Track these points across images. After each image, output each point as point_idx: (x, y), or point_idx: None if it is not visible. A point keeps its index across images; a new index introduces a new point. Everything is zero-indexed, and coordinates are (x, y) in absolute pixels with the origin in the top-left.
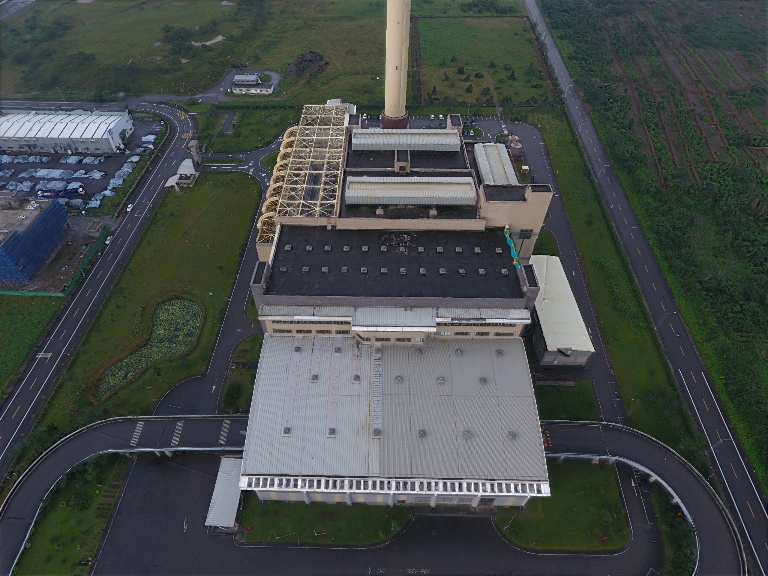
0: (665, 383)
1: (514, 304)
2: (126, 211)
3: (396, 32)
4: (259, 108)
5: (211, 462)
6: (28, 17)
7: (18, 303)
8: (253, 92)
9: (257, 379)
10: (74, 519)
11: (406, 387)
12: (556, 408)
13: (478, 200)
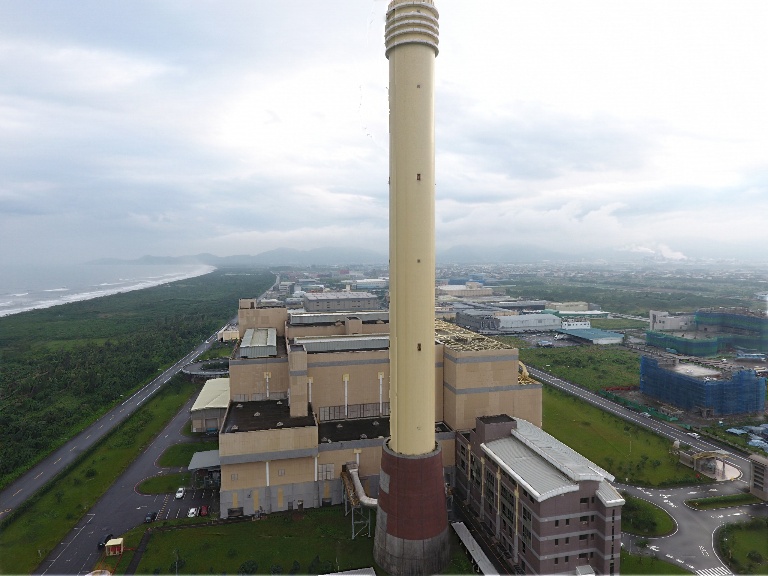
0: (158, 398)
1: None
2: None
3: None
4: None
5: None
6: None
7: None
8: None
9: None
10: None
11: None
12: None
13: None
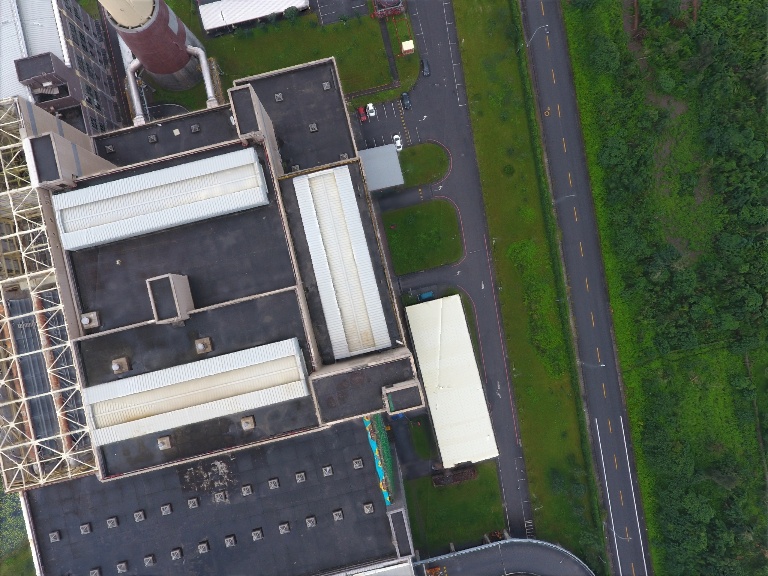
0: (577, 445)
1: None
2: None
3: None
4: None
5: None
6: None
7: None
8: None
9: None
10: None
11: None
12: (456, 510)
13: None
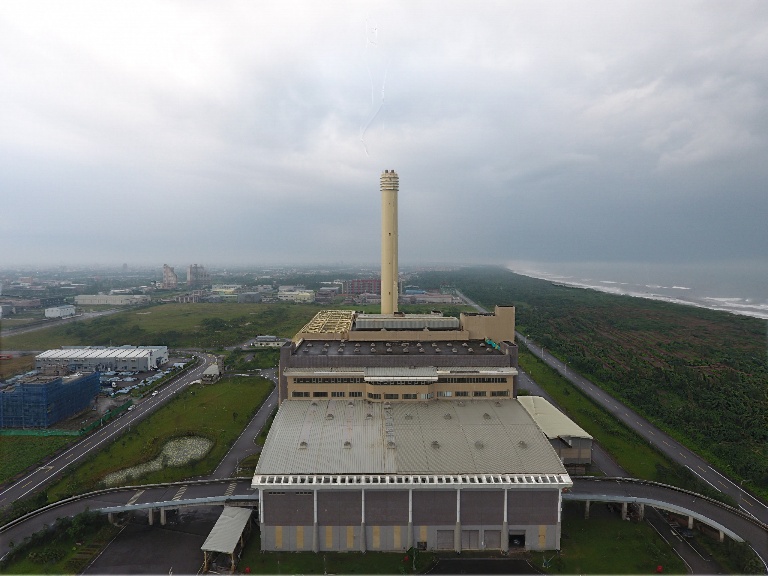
0: (675, 471)
1: (501, 362)
2: (151, 395)
3: (388, 269)
4: (276, 351)
5: (208, 527)
6: (95, 319)
7: (32, 439)
8: (271, 345)
9: (276, 418)
10: (39, 569)
11: (416, 421)
12: None
13: (460, 323)
